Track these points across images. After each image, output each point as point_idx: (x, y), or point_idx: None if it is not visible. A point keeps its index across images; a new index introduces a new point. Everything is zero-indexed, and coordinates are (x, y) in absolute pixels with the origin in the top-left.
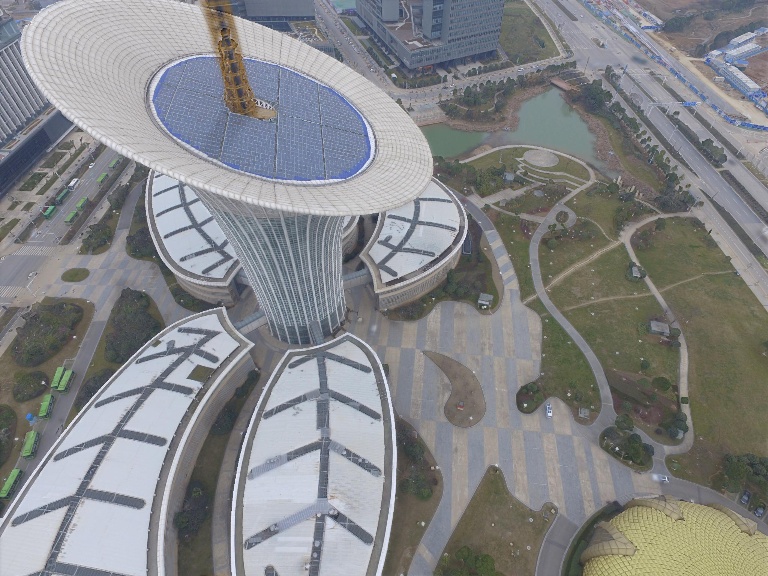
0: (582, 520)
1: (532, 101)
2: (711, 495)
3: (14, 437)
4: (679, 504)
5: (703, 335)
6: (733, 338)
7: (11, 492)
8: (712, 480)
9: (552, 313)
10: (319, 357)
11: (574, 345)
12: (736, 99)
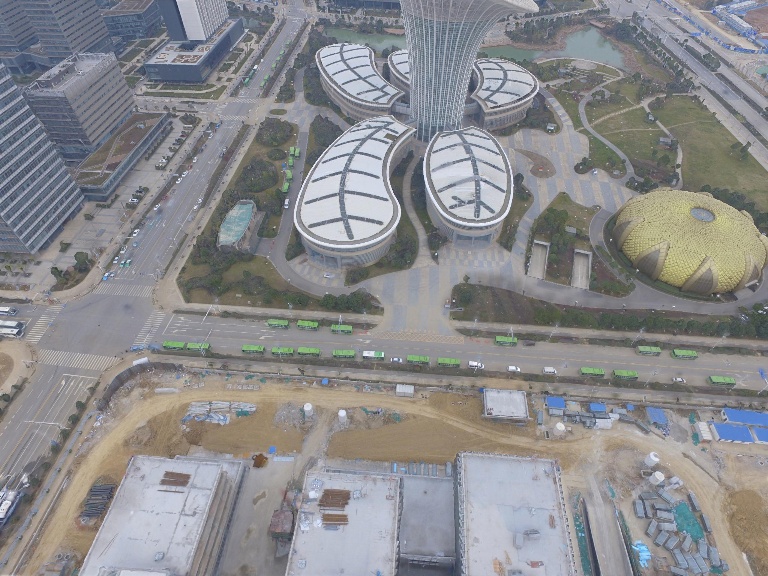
0: (615, 211)
1: (574, 38)
2: None
3: (277, 173)
4: None
5: (693, 146)
6: (712, 147)
7: (287, 192)
8: None
9: (595, 135)
10: None
11: (610, 149)
12: (733, 35)
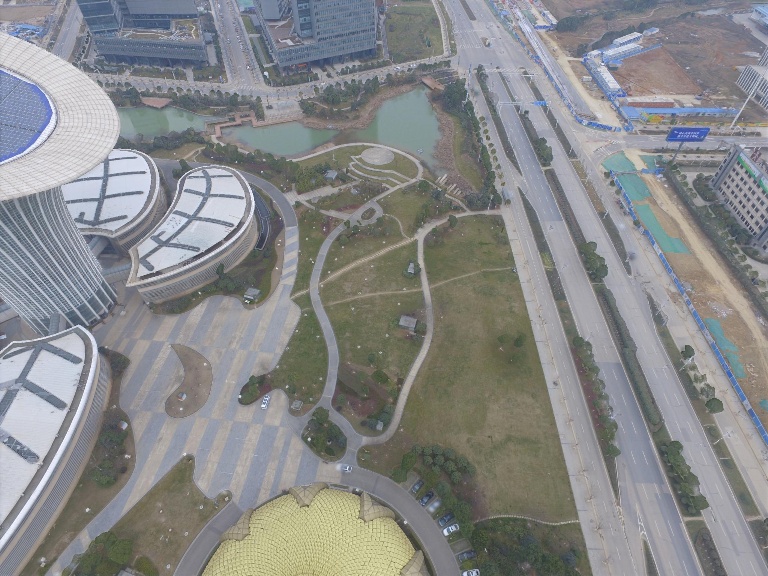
0: None
1: (404, 100)
2: (387, 484)
3: None
4: (321, 492)
5: (451, 330)
6: (477, 333)
7: None
8: (394, 470)
9: (315, 308)
10: (37, 348)
11: (321, 339)
12: (596, 99)
